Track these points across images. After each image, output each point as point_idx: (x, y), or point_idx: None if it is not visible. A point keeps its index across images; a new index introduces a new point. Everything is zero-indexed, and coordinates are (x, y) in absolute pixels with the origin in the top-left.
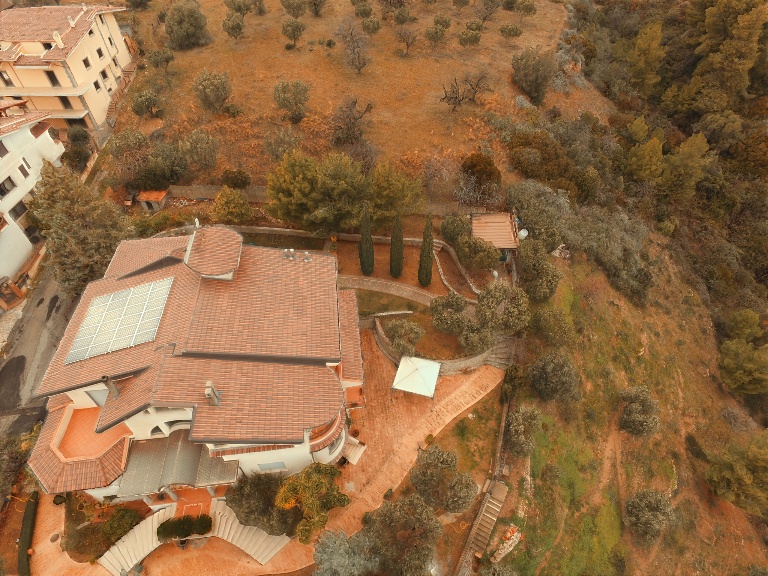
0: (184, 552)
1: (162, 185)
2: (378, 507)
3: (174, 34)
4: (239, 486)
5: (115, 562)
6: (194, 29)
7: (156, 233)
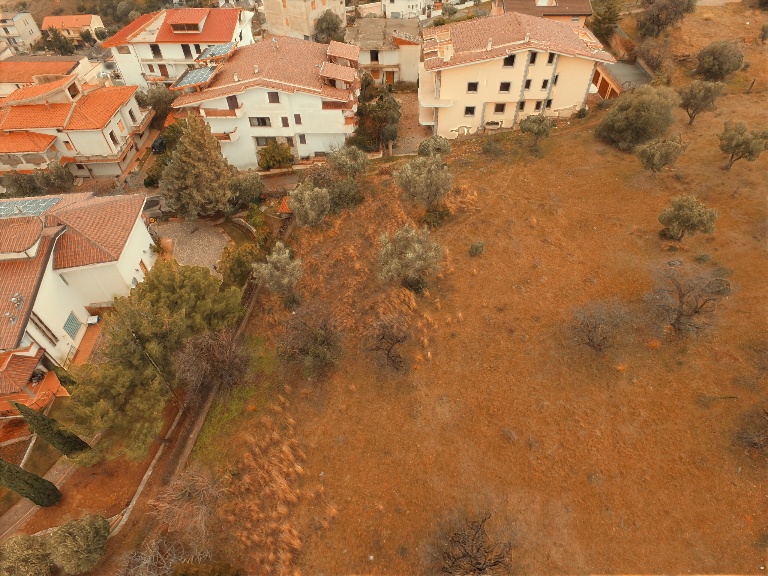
0: None
1: None
2: None
3: None
4: None
5: None
6: (628, 126)
7: None
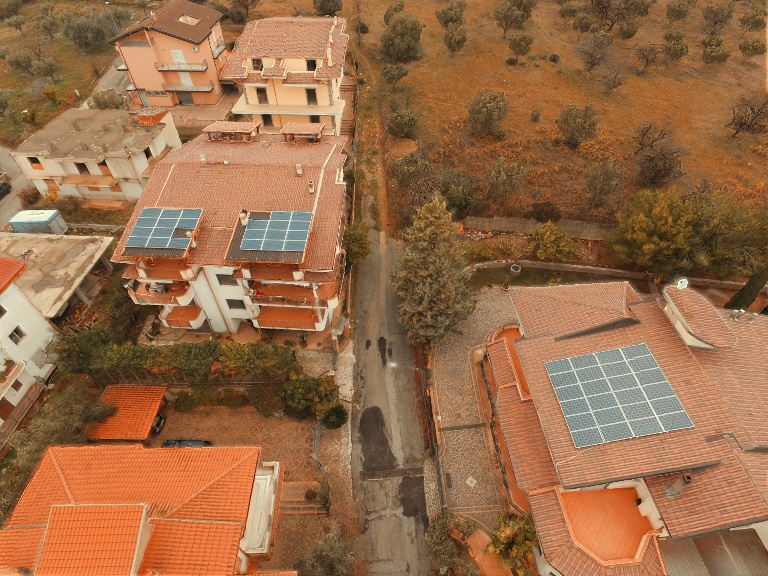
0: None
1: (459, 216)
2: None
3: (395, 47)
4: None
5: None
6: (414, 42)
7: None
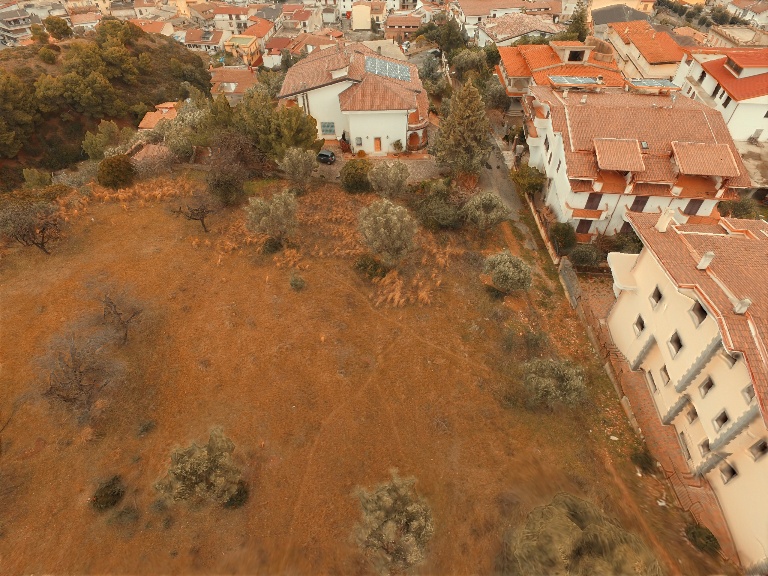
0: None
1: None
2: None
3: None
4: None
5: None
6: None
7: None
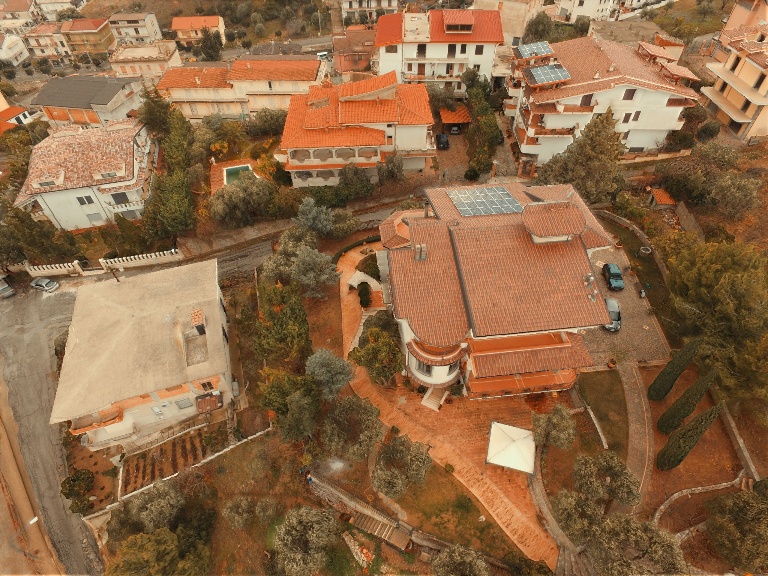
0: (360, 308)
1: (679, 196)
2: (386, 423)
3: None
4: (389, 314)
5: (356, 277)
6: None
7: (624, 217)
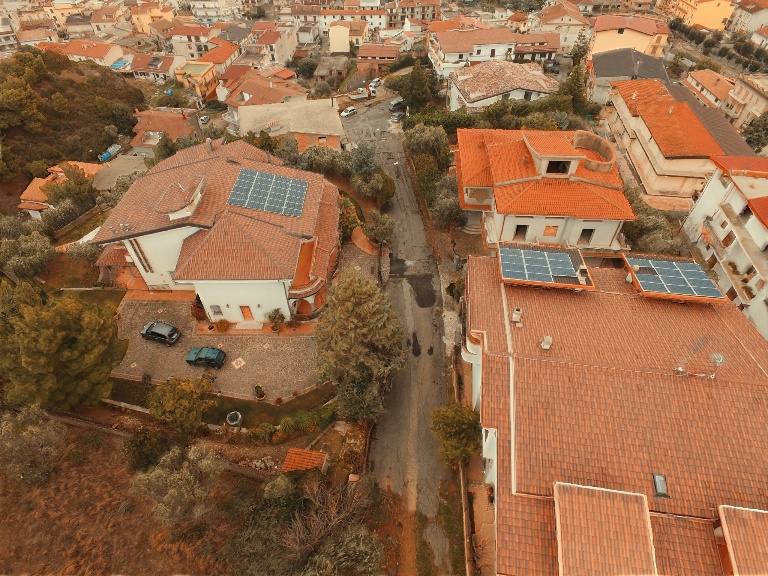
0: None
1: None
2: None
3: None
4: None
5: None
6: None
7: None
